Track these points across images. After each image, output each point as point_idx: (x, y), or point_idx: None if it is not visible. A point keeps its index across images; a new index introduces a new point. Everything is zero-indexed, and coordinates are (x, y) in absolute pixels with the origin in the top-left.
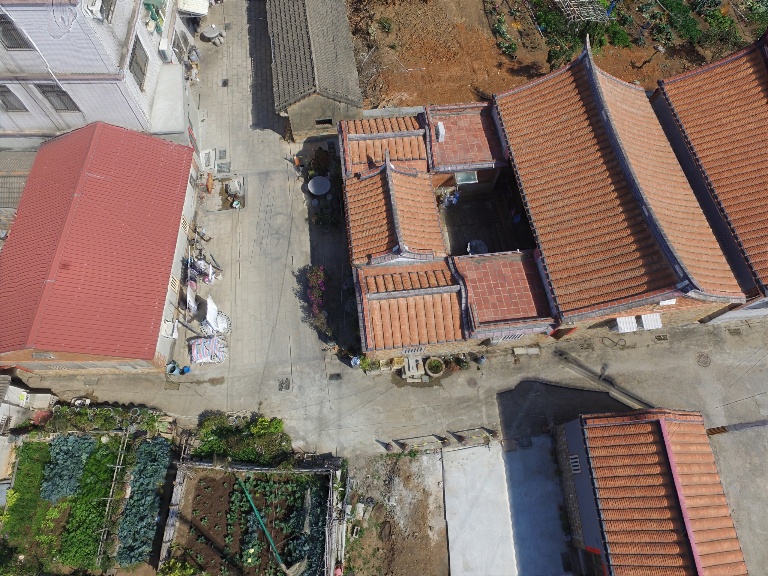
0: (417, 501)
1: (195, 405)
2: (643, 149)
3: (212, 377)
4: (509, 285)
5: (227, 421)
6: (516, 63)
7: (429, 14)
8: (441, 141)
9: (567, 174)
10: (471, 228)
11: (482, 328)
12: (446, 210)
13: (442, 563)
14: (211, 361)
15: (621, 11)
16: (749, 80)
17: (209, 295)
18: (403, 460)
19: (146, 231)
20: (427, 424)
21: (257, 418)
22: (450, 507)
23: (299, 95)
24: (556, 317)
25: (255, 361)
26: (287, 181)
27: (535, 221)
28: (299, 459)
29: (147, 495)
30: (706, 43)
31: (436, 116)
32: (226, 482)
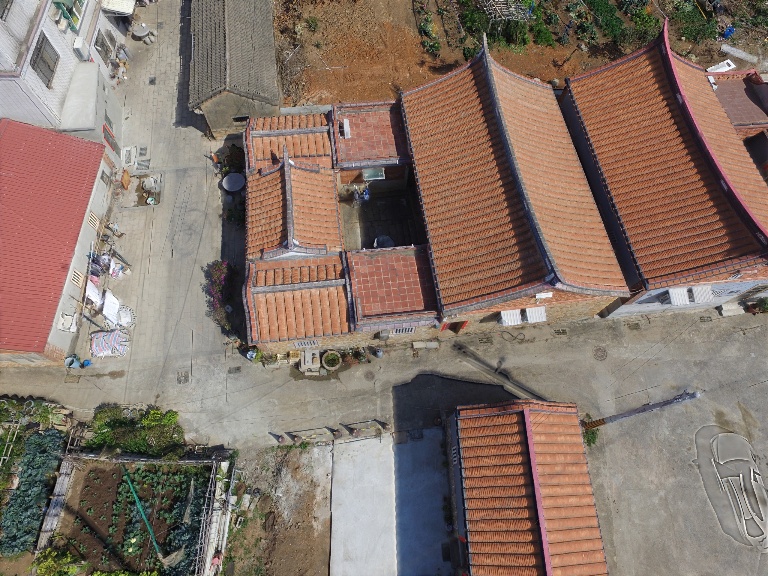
0: (303, 492)
1: (93, 398)
2: (540, 145)
3: (112, 370)
4: (399, 279)
5: (121, 413)
6: (439, 61)
7: (357, 13)
8: (347, 138)
9: (461, 170)
10: (383, 224)
11: (364, 321)
12: (360, 206)
13: (323, 553)
14: (112, 355)
15: (548, 10)
16: (648, 77)
17: (108, 289)
18: (294, 452)
19: (46, 226)
20: (321, 417)
21: (150, 410)
22: (336, 498)
23: (210, 92)
24: (439, 310)
25: (156, 355)
26: (204, 178)
27: (428, 216)
28: (190, 451)
29: (34, 486)
30: (624, 42)
31: (345, 113)
32: (115, 473)
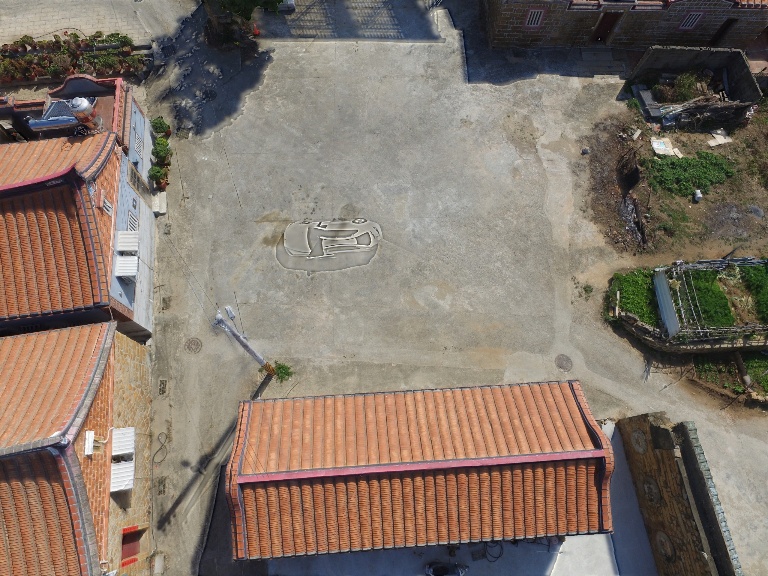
0: None
1: None
2: None
3: None
4: None
5: None
6: None
7: None
8: None
9: None
10: None
11: None
12: None
13: None
14: None
15: None
16: None
17: None
18: None
19: None
20: None
21: None
22: None
23: None
24: None
25: None
26: None
27: None
28: None
29: None
30: None
31: None
32: None
